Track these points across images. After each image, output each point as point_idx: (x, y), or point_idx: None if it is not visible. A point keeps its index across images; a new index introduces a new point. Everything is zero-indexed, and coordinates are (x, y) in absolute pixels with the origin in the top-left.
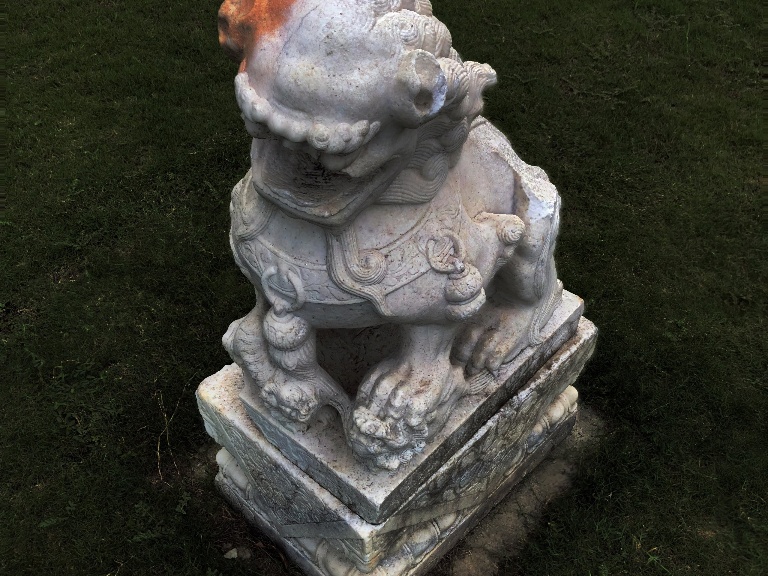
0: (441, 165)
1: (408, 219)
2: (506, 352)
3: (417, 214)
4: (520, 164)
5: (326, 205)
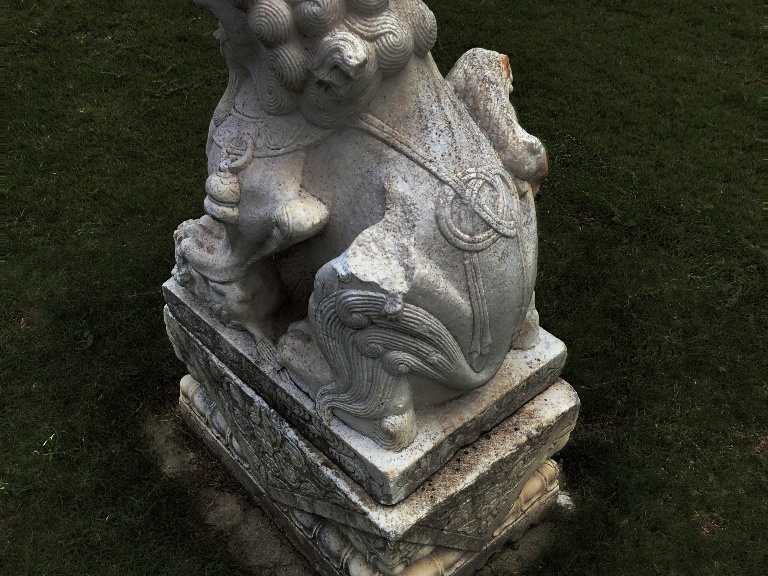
0: (273, 86)
1: (254, 109)
2: (287, 360)
3: (259, 113)
4: (406, 236)
5: (222, 30)
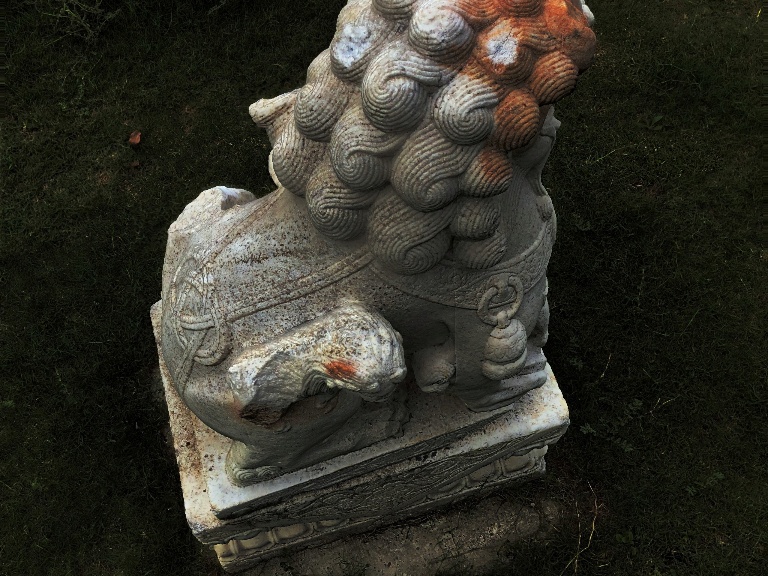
0: None
1: None
2: None
3: None
4: None
5: None
